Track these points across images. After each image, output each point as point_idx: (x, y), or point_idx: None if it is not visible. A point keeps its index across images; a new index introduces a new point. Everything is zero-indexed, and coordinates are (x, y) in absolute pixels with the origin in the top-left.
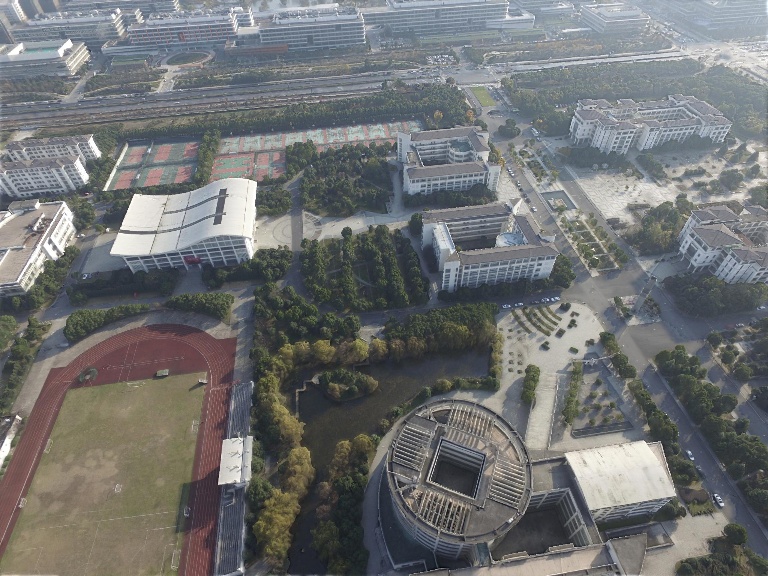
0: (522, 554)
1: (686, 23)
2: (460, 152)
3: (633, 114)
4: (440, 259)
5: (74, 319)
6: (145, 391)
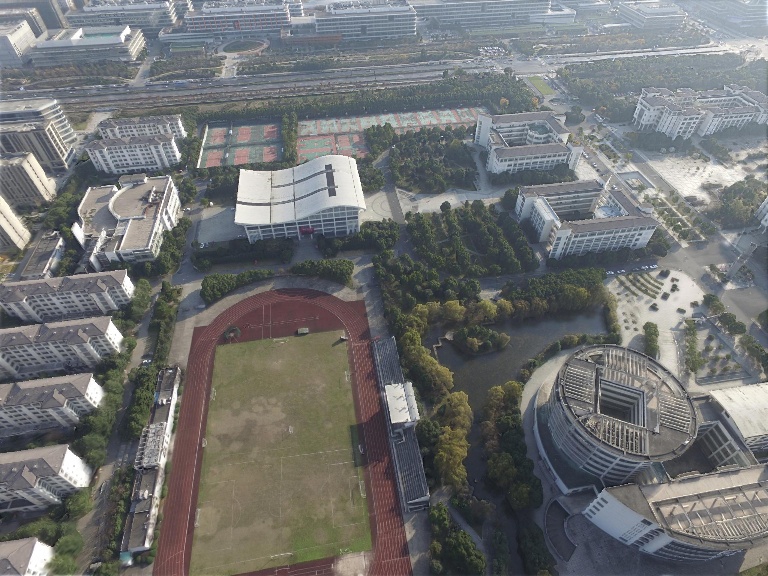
0: (695, 473)
1: (719, 20)
2: (540, 134)
3: (693, 102)
4: (543, 230)
5: (209, 282)
6: (290, 347)
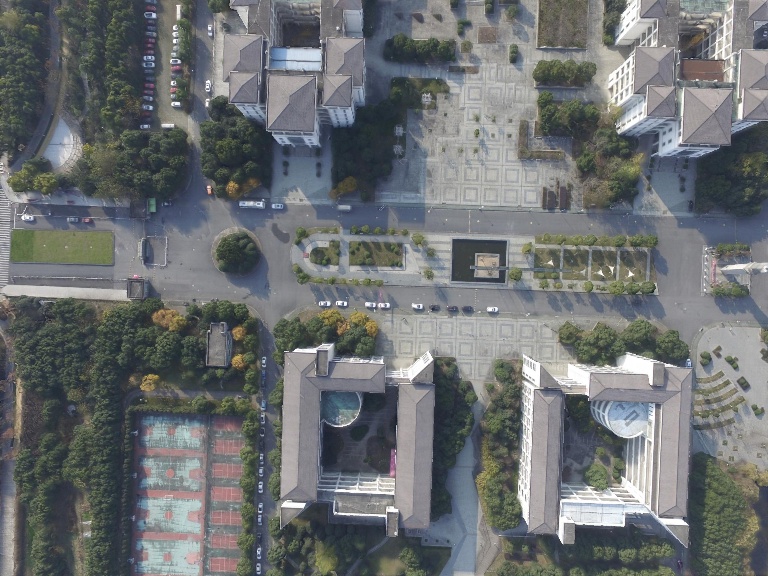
0: None
1: None
2: (358, 413)
3: (282, 1)
4: None
5: None
6: None
